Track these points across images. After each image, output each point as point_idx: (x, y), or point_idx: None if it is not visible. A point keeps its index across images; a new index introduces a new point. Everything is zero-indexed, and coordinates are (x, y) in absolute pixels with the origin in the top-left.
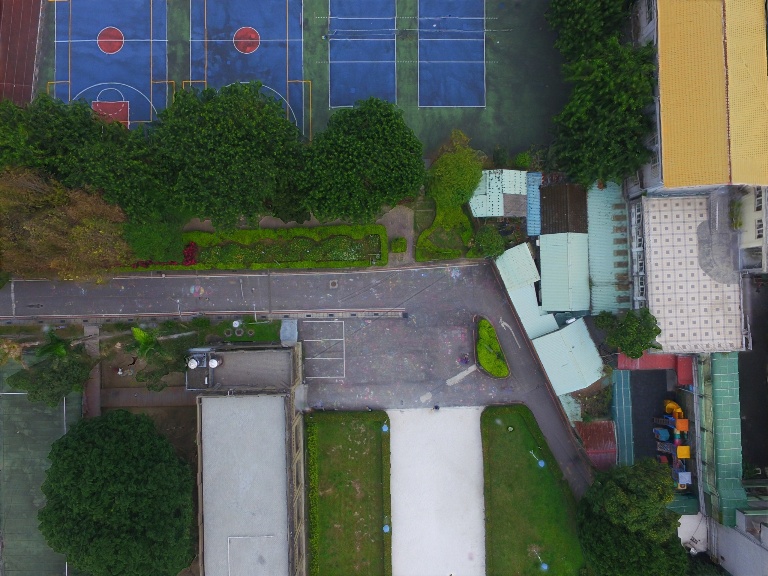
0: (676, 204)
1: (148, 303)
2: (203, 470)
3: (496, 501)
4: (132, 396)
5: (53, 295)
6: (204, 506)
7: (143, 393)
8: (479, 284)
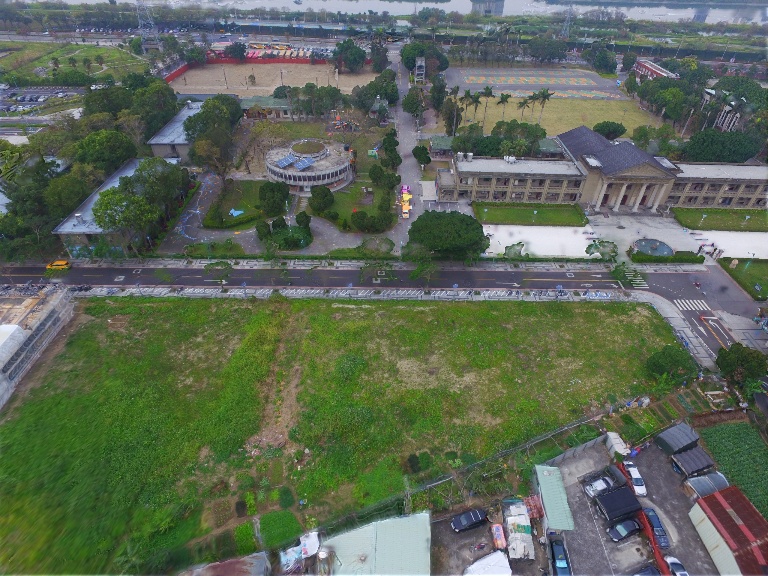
0: None
1: None
2: None
3: None
4: None
5: (753, 161)
6: None
7: None
8: None
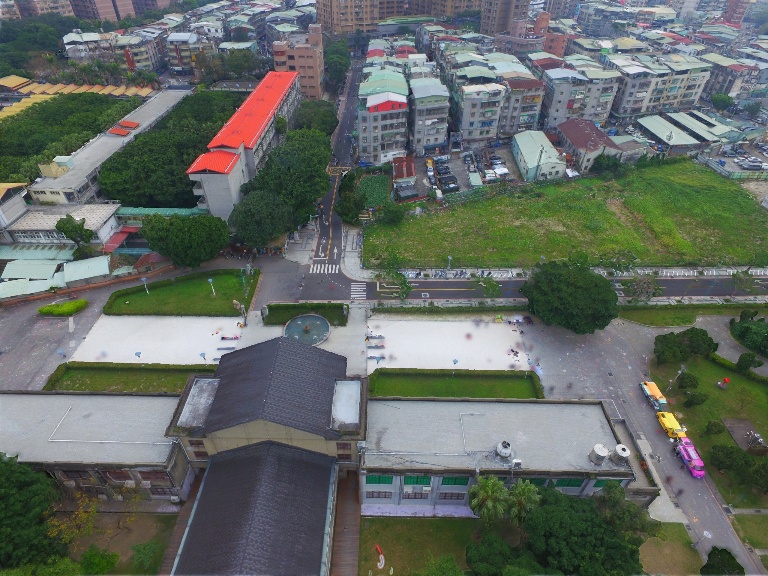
0: (24, 220)
1: None
2: None
3: None
4: None
5: None
6: None
7: None
8: (14, 313)
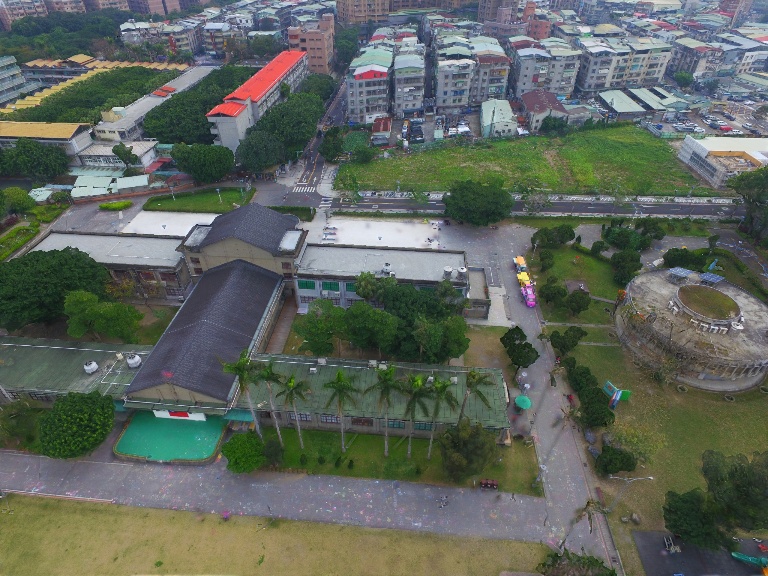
0: None
1: None
2: None
3: None
4: None
5: None
6: None
7: None
8: (82, 208)
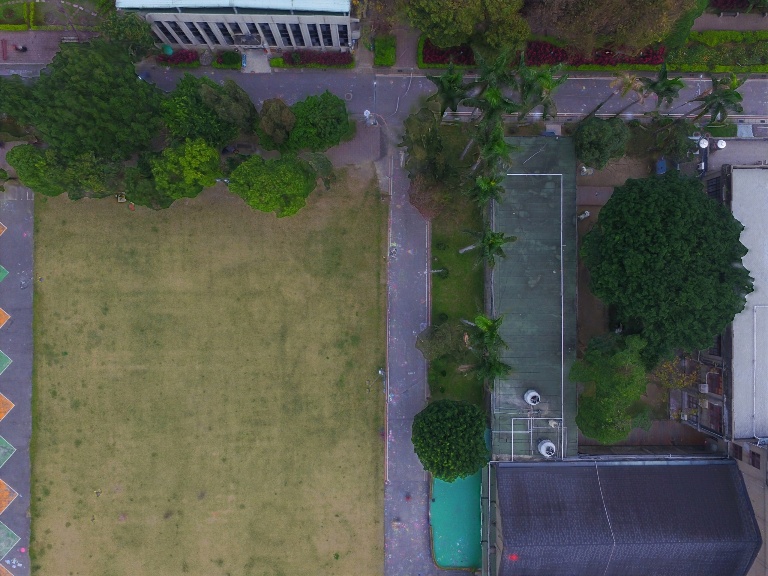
0: None
1: (609, 104)
2: None
3: None
4: (593, 194)
5: None
6: None
7: (604, 192)
8: None
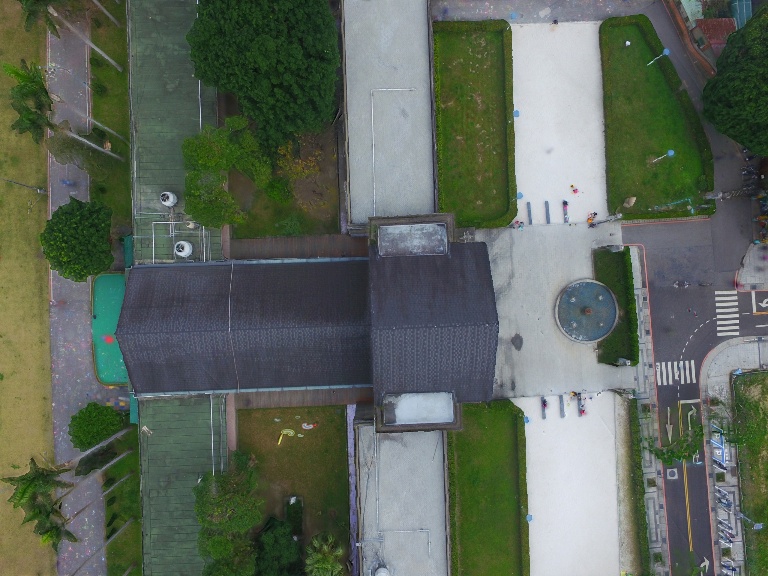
0: None
1: None
2: (345, 25)
3: (615, 113)
4: None
5: None
6: (346, 61)
7: None
8: None
